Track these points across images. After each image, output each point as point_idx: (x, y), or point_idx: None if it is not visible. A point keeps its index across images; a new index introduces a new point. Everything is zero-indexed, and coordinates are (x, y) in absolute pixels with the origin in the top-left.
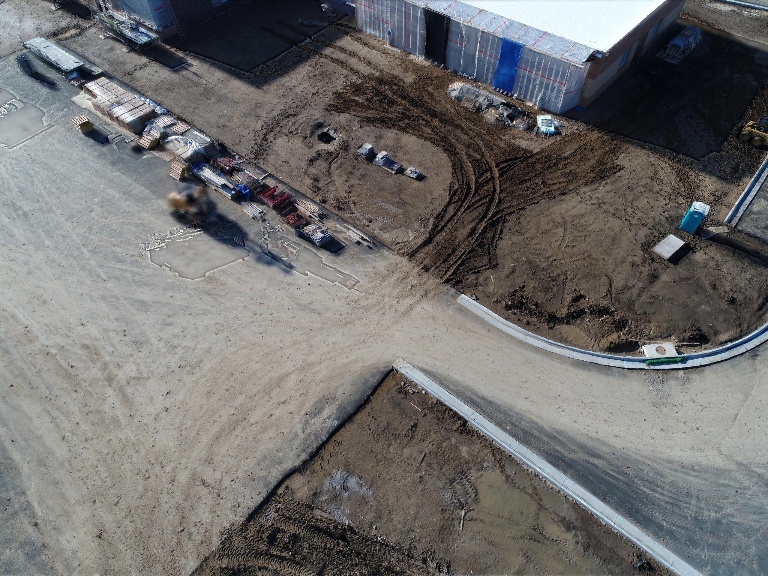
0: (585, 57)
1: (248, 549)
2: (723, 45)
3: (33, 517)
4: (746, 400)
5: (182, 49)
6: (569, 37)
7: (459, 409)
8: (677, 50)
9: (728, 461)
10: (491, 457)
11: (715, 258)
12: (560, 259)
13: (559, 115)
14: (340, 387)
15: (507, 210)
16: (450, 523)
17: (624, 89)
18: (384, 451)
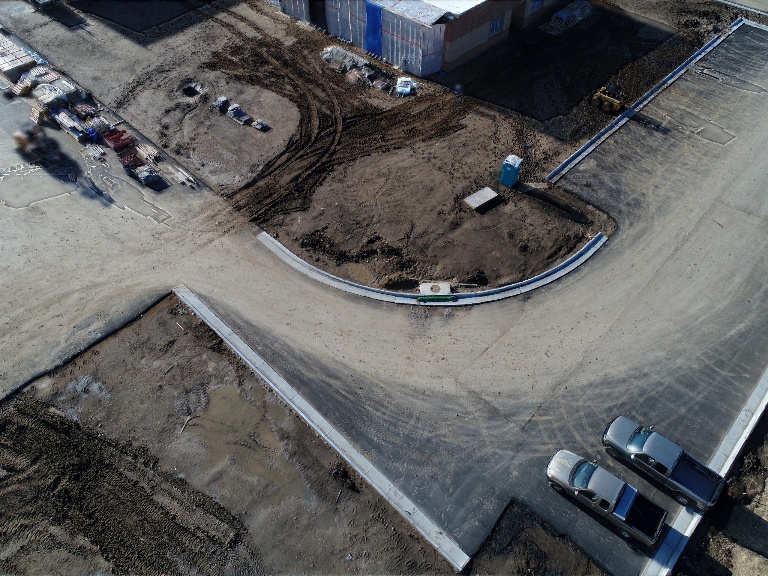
0: (436, 18)
1: None
2: (611, 20)
3: None
4: (502, 336)
5: (85, 11)
6: (434, 2)
7: (219, 330)
8: (560, 22)
9: (461, 388)
10: (234, 373)
11: (523, 210)
12: (372, 205)
13: (421, 78)
14: (116, 305)
15: (338, 160)
16: (172, 426)
17: (494, 56)
18: (135, 362)
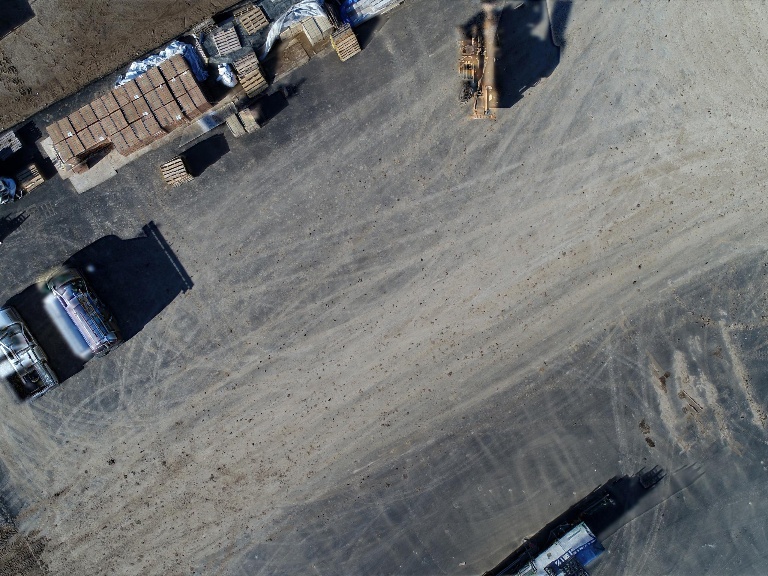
0: None
1: None
2: None
3: None
4: None
5: None
6: None
7: None
8: None
9: None
10: None
11: None
12: None
13: None
14: None
15: None
16: None
17: None
18: None
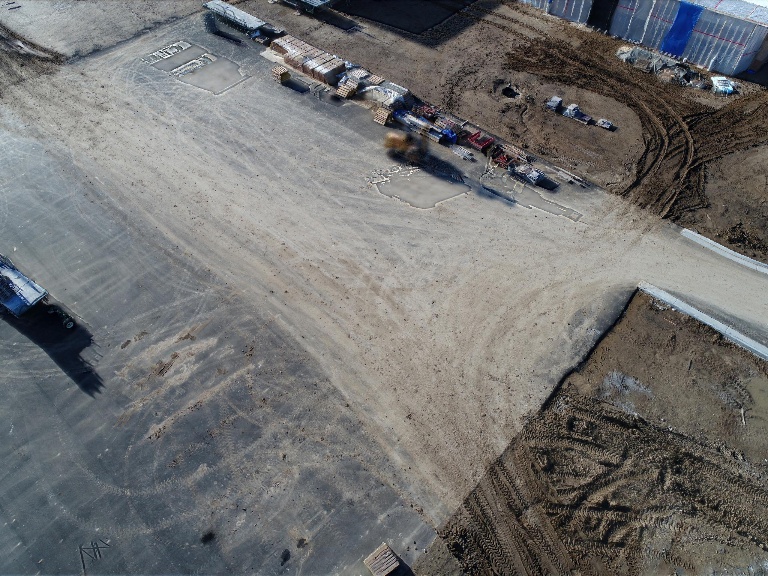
0: None
1: (550, 433)
2: None
3: (343, 399)
4: None
5: (350, 13)
6: None
7: (713, 324)
8: None
9: None
10: (755, 366)
11: None
12: None
13: (732, 77)
14: (593, 303)
15: (705, 158)
16: (732, 419)
17: None
18: (651, 357)
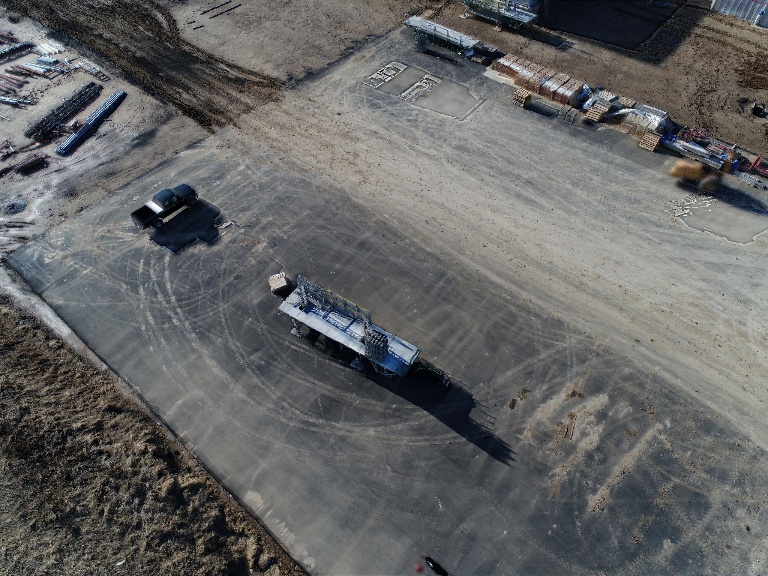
0: None
1: None
2: None
3: None
4: None
5: (552, 28)
6: None
7: None
8: None
9: None
10: None
11: None
12: None
13: None
14: None
15: None
16: None
17: None
18: None
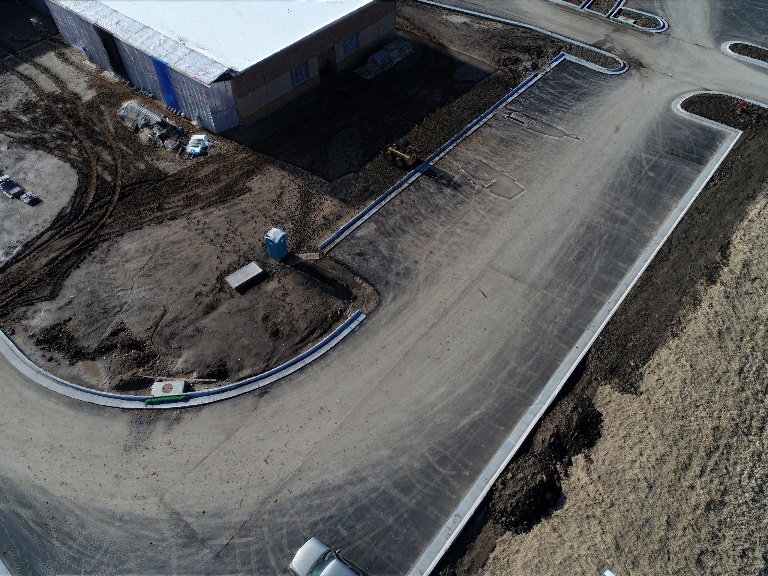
0: (215, 76)
1: None
2: (430, 59)
3: None
4: (224, 442)
5: None
6: (226, 54)
7: None
8: (376, 65)
9: (163, 509)
10: None
11: (286, 287)
12: (126, 289)
13: (216, 135)
14: None
15: (104, 237)
16: None
17: (300, 106)
18: None
